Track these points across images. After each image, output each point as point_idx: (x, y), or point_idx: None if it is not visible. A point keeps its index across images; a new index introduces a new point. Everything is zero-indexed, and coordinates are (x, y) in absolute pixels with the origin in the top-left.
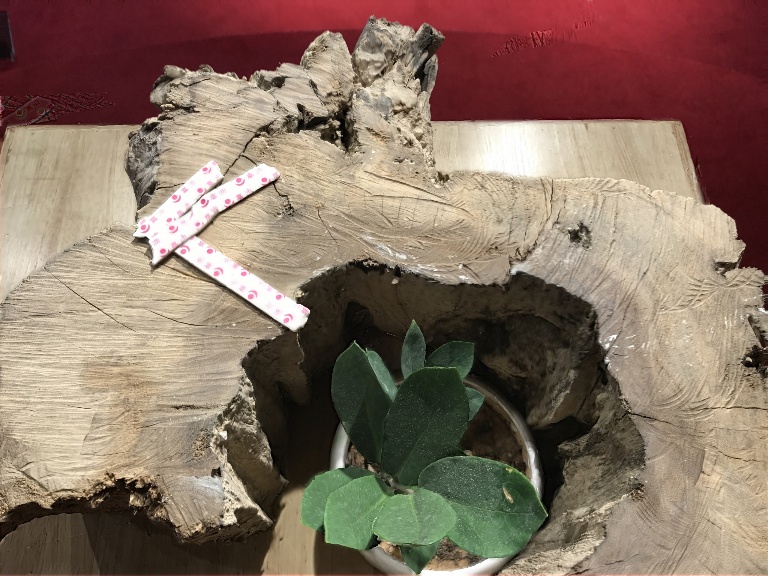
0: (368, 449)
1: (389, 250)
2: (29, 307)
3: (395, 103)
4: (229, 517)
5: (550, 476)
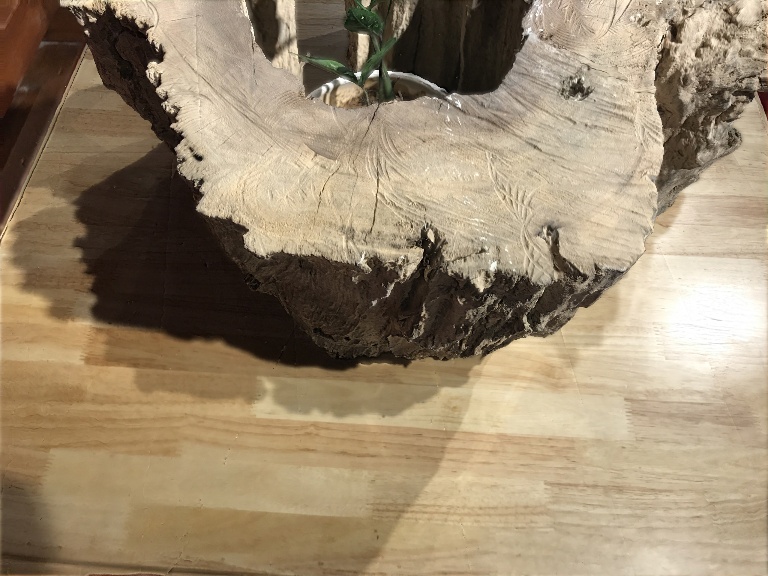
0: None
1: None
2: None
3: (738, 5)
4: None
5: None
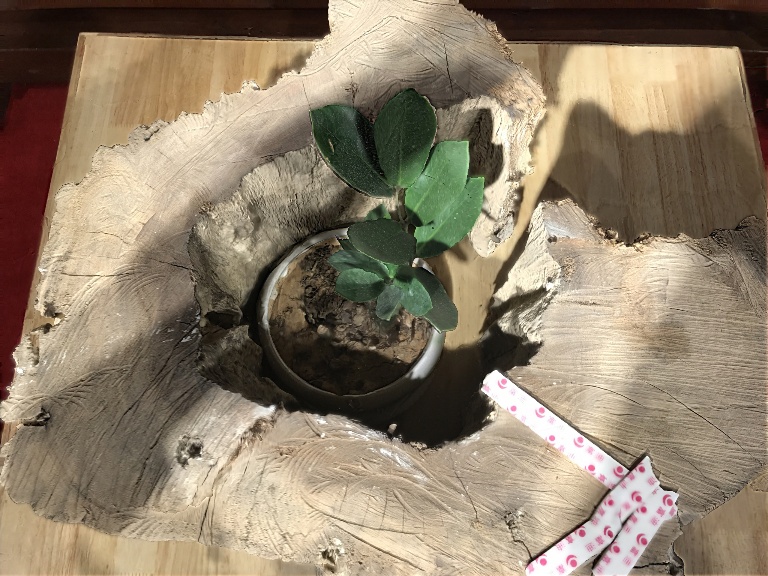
0: (423, 275)
1: (398, 460)
2: (761, 417)
3: None
4: (537, 216)
5: (247, 319)
